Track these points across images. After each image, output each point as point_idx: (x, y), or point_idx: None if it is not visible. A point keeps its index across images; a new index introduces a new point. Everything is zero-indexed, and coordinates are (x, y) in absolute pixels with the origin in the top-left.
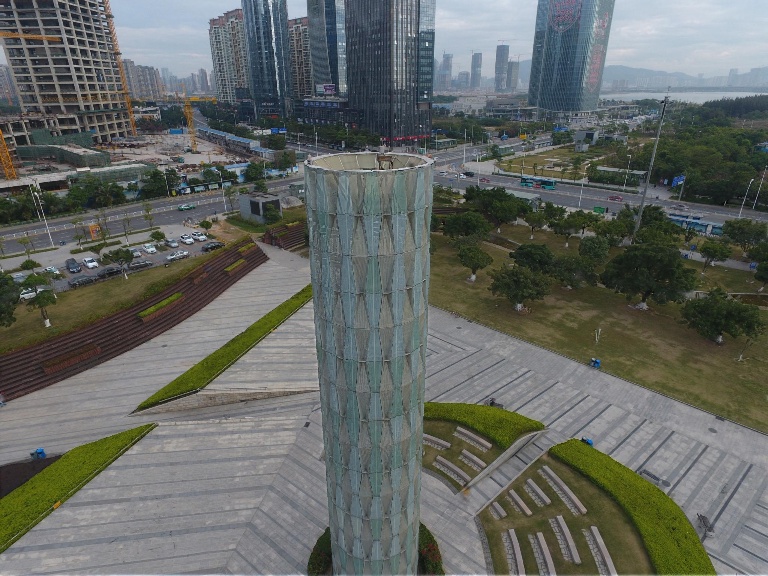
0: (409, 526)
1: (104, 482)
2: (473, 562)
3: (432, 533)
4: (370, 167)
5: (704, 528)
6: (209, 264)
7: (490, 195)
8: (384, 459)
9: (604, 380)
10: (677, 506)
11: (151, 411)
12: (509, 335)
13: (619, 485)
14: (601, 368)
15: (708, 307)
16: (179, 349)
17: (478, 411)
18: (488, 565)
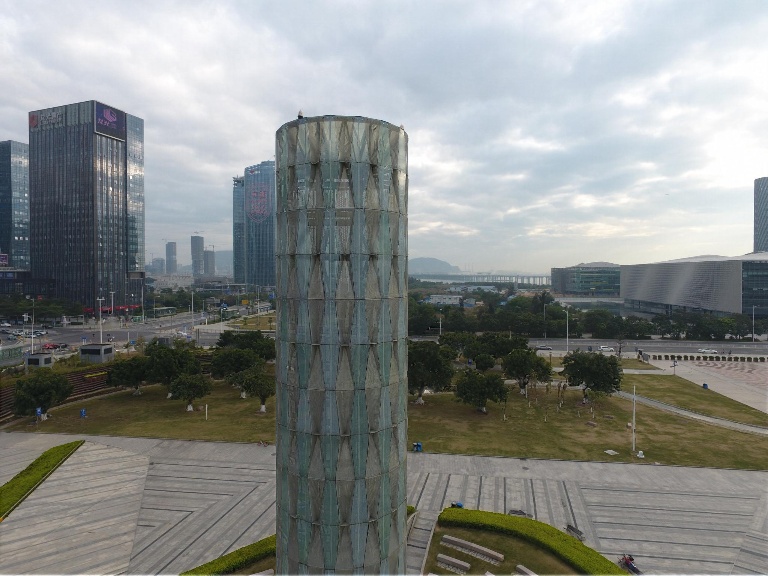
0: None
1: None
2: None
3: None
4: None
5: (575, 535)
6: None
7: (247, 338)
8: None
9: (432, 459)
10: (551, 526)
11: None
12: None
13: (509, 524)
14: (423, 450)
15: (471, 383)
16: None
17: None
18: None
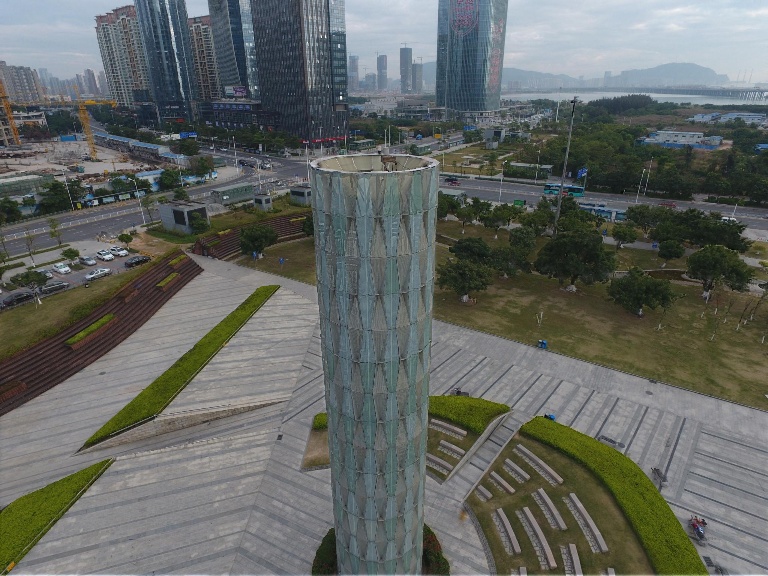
0: (419, 521)
1: (63, 532)
2: (470, 546)
3: (427, 525)
4: (367, 169)
5: (659, 479)
6: (139, 280)
7: None
8: (399, 458)
9: (552, 359)
10: (635, 464)
11: (102, 446)
12: (460, 326)
13: (586, 452)
14: (548, 348)
15: (629, 284)
16: (120, 375)
17: (448, 401)
18: (484, 546)
